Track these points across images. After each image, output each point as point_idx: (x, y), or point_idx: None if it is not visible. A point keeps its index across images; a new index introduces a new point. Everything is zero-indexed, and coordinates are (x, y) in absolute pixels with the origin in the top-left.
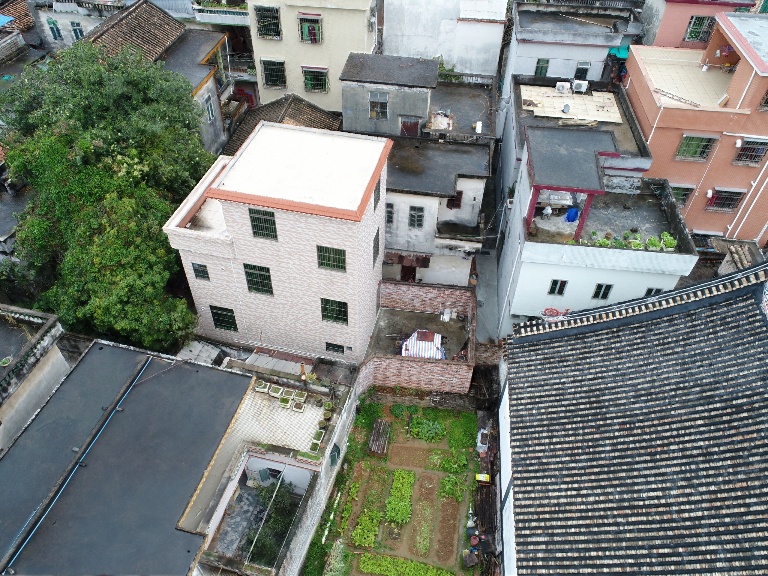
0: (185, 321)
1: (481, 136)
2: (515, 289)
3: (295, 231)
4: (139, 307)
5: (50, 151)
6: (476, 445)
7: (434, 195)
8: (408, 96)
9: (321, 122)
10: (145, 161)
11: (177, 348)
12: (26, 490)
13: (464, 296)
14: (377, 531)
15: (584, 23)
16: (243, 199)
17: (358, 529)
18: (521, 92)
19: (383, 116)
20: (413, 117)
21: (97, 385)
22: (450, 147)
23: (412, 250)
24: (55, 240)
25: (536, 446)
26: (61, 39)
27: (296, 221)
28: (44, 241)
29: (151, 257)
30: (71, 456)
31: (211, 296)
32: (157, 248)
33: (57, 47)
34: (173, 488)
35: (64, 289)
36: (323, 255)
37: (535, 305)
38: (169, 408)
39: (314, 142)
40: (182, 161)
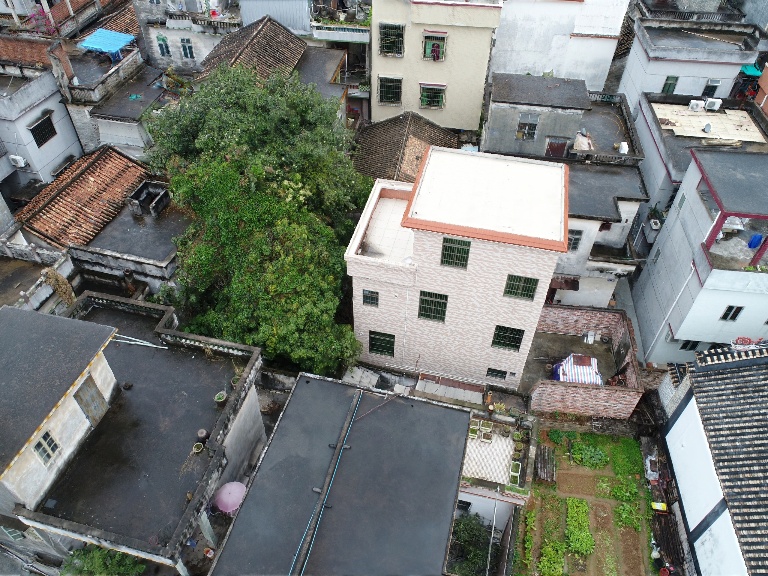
0: (353, 348)
1: (630, 157)
2: (686, 315)
3: (488, 260)
4: (314, 335)
5: (223, 177)
6: (642, 472)
7: (599, 219)
8: (560, 117)
9: (441, 140)
10: (307, 185)
11: (340, 374)
12: (279, 533)
13: (612, 318)
14: (563, 562)
15: (710, 40)
16: (442, 229)
17: (544, 561)
18: (654, 110)
19: (530, 137)
20: (562, 138)
21: (316, 421)
22: (598, 168)
23: (560, 272)
24: (218, 266)
25: (749, 480)
26: (168, 55)
27: (493, 251)
28: (210, 267)
29: (323, 284)
30: (313, 497)
31: (374, 322)
32: (325, 274)
33: (163, 63)
34: (426, 531)
35: (225, 315)
36: (512, 284)
37: (703, 330)
38: (396, 445)
39: (490, 168)
40: (341, 185)
